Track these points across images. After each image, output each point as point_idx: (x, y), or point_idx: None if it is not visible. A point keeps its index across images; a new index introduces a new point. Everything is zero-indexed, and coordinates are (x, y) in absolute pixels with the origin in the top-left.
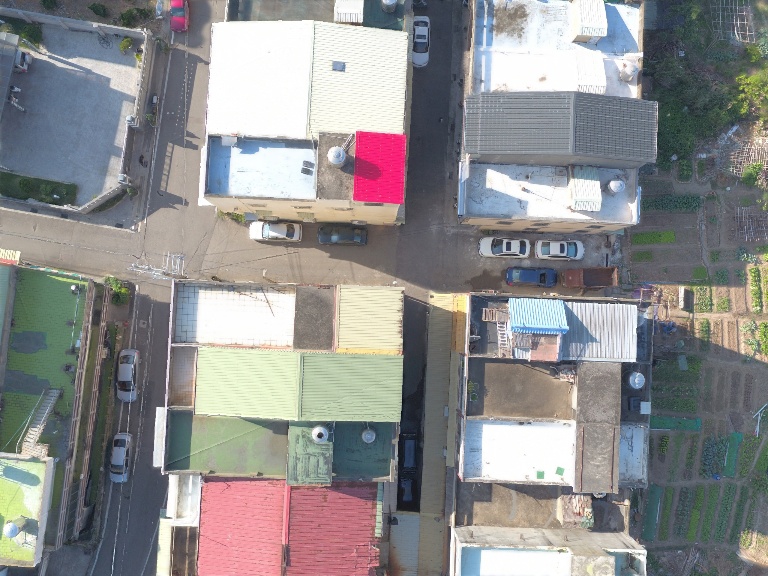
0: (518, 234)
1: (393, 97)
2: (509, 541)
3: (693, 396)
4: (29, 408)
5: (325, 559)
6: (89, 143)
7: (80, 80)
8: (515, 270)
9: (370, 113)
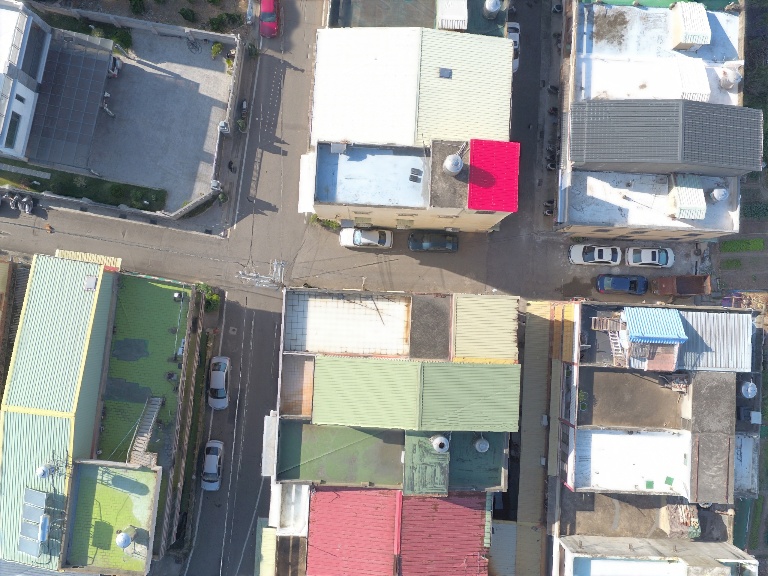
0: (608, 241)
1: (499, 104)
2: (619, 551)
3: None
4: (131, 416)
5: (436, 569)
6: (178, 149)
7: (169, 85)
8: (607, 278)
9: (476, 120)
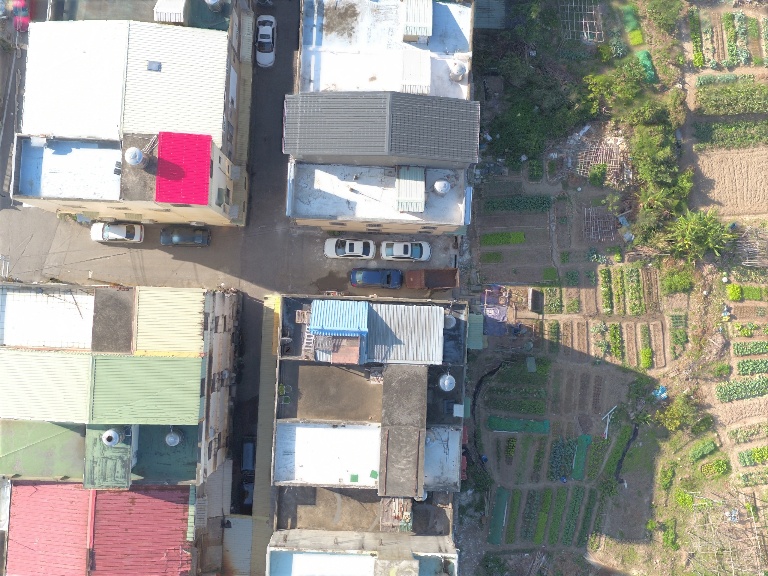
0: (365, 235)
1: (212, 97)
2: (321, 545)
3: (541, 398)
4: None
5: (133, 563)
6: None
7: None
8: (358, 271)
9: (187, 113)
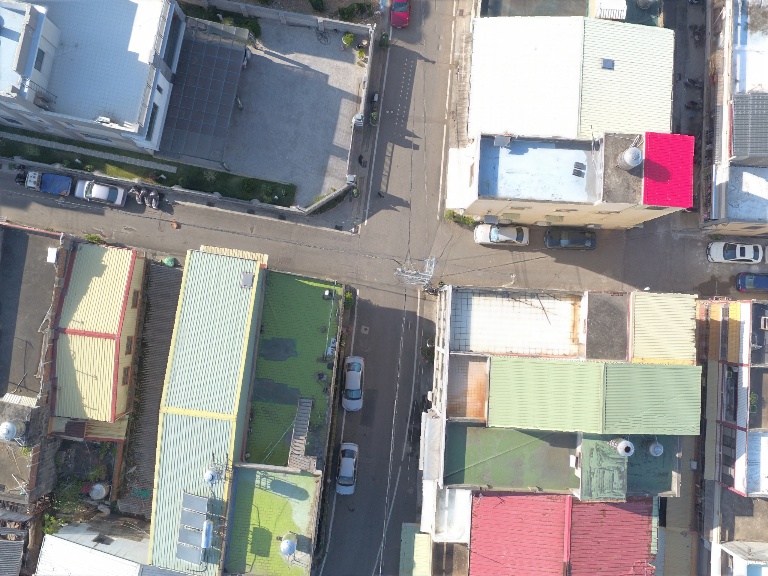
0: (746, 239)
1: (660, 97)
2: None
3: None
4: (279, 418)
5: None
6: (307, 142)
7: (297, 77)
8: (748, 276)
9: (638, 113)
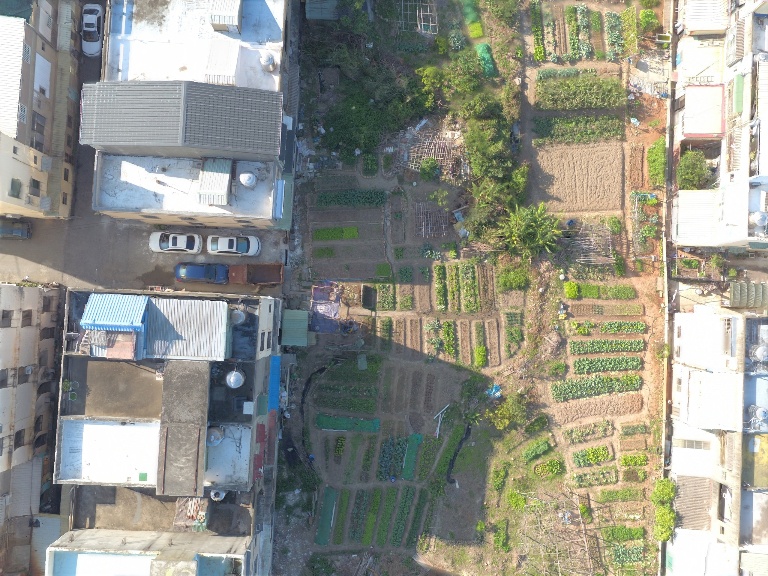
0: (193, 229)
1: (6, 85)
2: (106, 545)
3: (372, 396)
4: None
5: None
6: None
7: None
8: (182, 266)
9: None
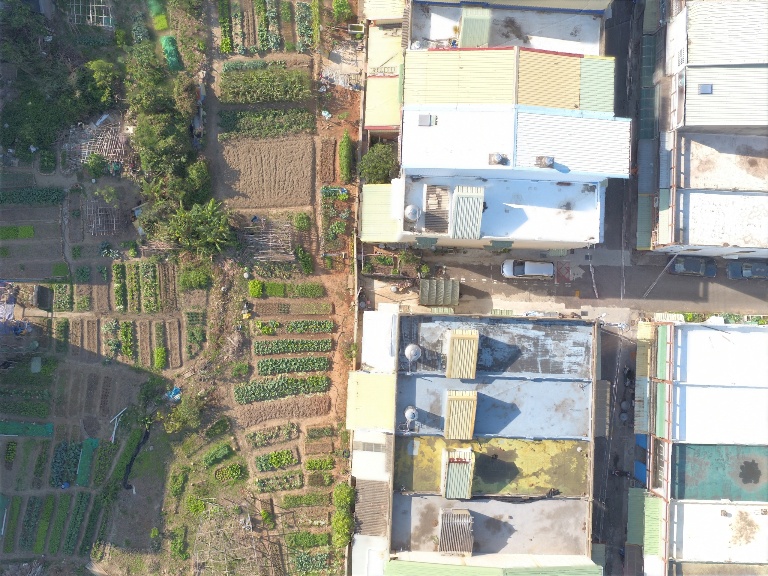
0: None
1: None
2: None
3: (45, 400)
4: None
5: None
6: None
7: None
8: None
9: None
